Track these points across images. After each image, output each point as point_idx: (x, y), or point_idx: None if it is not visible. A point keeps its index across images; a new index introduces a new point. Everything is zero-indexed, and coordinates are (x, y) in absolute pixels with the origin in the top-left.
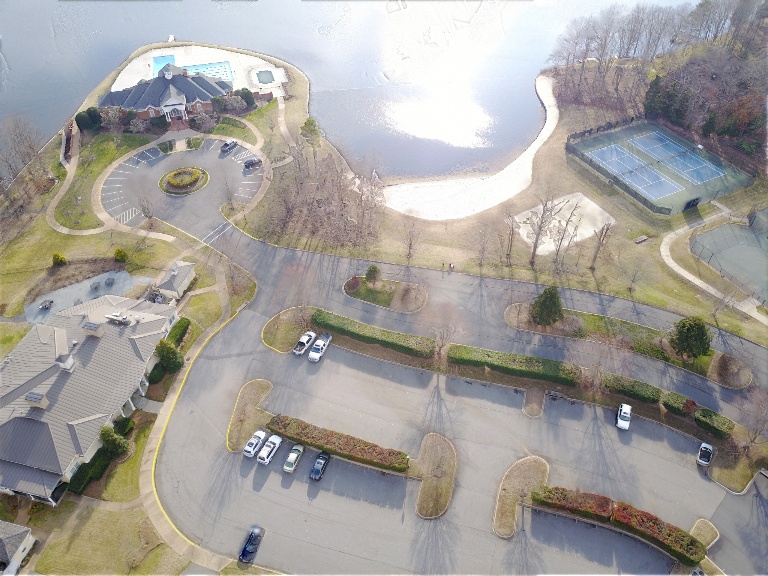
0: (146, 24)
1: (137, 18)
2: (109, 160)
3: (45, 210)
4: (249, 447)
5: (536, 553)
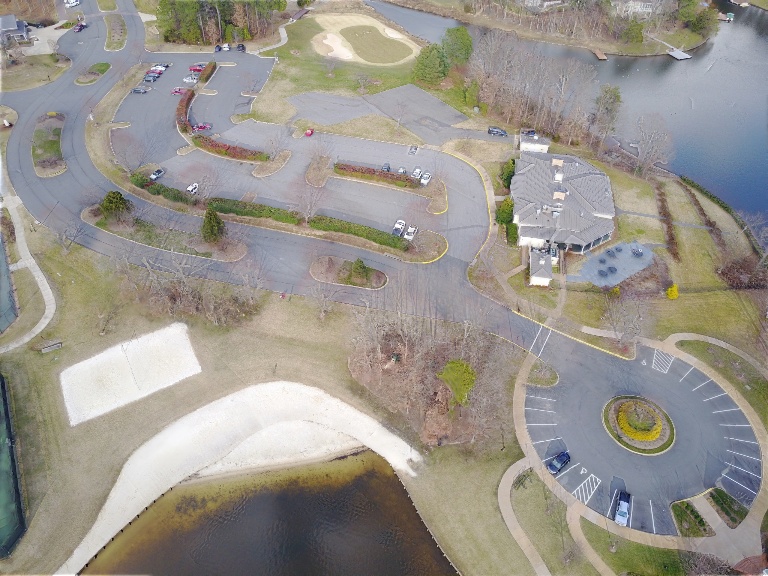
0: None
1: None
2: None
3: None
4: None
5: None
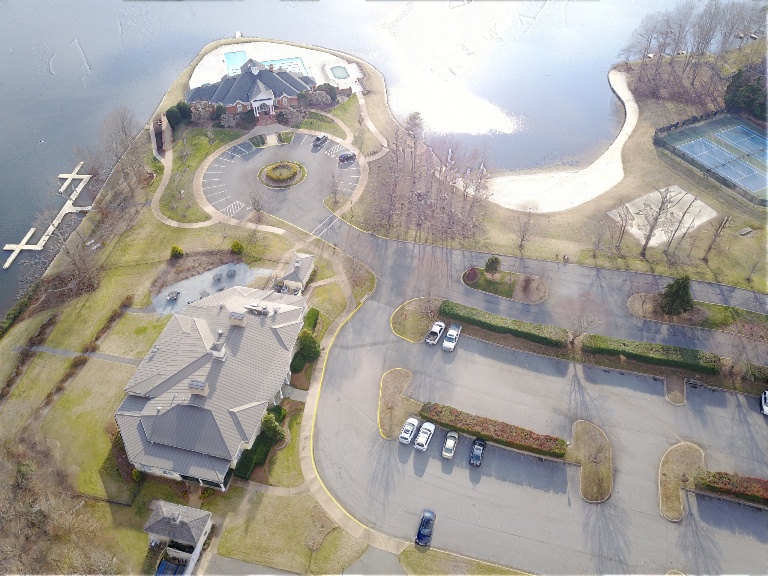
0: (210, 20)
1: (202, 14)
2: (204, 154)
3: (149, 204)
4: (406, 434)
5: (708, 536)
